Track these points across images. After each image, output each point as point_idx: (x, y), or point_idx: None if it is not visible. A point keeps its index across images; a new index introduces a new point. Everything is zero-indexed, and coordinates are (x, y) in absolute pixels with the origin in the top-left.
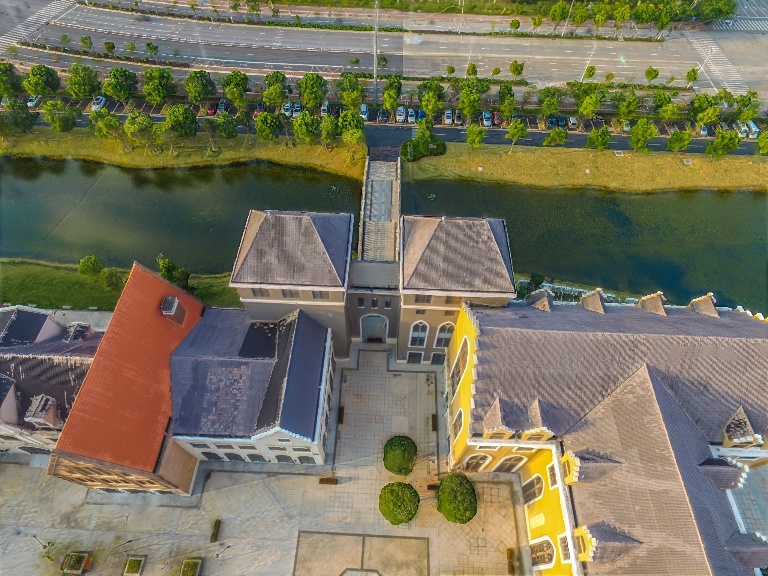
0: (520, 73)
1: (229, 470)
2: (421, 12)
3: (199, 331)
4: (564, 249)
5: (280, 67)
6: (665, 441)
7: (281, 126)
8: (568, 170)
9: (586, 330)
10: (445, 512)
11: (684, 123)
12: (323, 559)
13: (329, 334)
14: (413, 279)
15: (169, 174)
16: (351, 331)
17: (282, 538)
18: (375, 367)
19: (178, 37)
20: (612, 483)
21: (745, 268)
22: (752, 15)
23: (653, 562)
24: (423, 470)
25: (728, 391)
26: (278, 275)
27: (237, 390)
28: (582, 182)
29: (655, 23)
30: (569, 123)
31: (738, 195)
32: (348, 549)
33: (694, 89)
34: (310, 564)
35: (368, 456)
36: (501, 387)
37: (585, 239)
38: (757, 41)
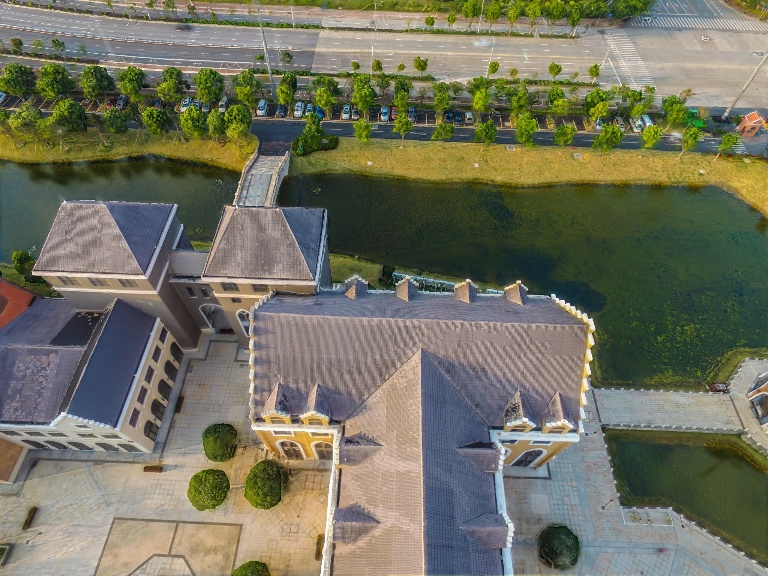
0: (424, 69)
1: (56, 458)
2: (342, 9)
3: (20, 320)
4: (439, 242)
5: (189, 63)
6: (418, 423)
7: (169, 121)
8: (457, 164)
9: (362, 315)
10: (248, 498)
11: (582, 118)
12: (132, 545)
13: (157, 323)
14: (212, 267)
15: (58, 169)
16: (193, 321)
17: (96, 525)
18: (223, 357)
19: (92, 34)
20: (371, 465)
21: (617, 260)
22: (673, 12)
23: (383, 541)
24: (251, 458)
25: (505, 376)
26: (79, 263)
27: (43, 377)
28: (470, 176)
29: (567, 20)
30: (465, 118)
31: (624, 189)
32: (159, 535)
33: (600, 85)
34: (118, 550)
35: (198, 444)
36: (281, 372)
37: (462, 232)
38: (672, 38)
